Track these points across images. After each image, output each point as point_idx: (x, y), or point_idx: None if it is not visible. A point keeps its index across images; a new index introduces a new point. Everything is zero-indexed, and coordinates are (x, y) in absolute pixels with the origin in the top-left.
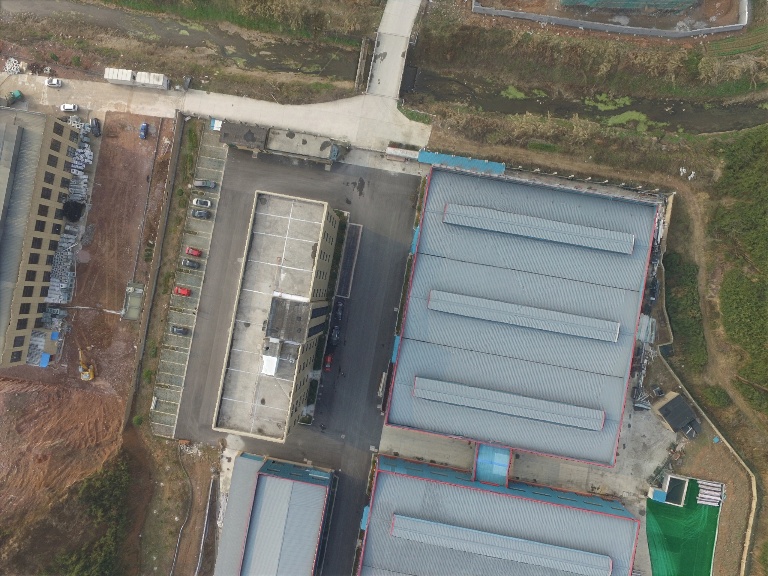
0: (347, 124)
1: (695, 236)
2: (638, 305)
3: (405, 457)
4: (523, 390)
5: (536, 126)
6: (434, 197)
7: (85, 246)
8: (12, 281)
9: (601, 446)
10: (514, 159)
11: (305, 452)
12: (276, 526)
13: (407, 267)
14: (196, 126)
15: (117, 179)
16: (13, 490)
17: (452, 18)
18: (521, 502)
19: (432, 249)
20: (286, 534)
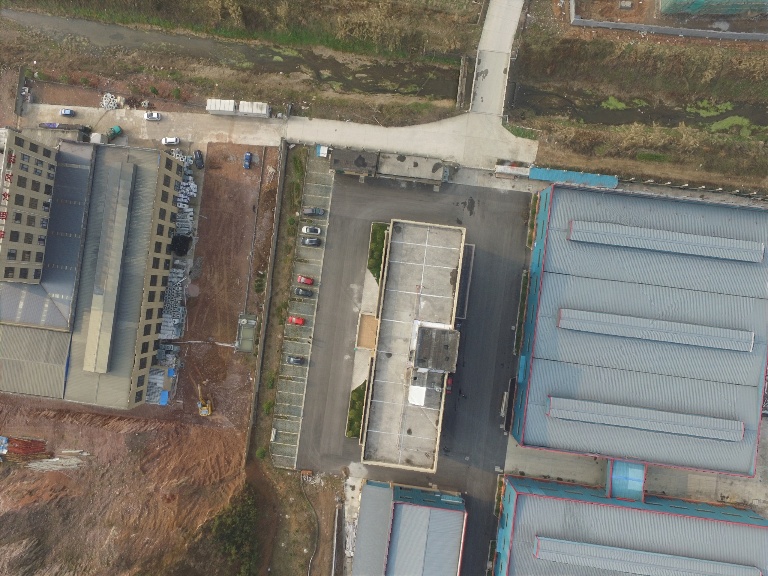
0: (453, 144)
1: None
2: None
3: (532, 476)
4: (657, 404)
5: (646, 137)
6: (556, 215)
7: (194, 280)
8: (134, 321)
9: (739, 456)
10: (624, 171)
11: (430, 476)
12: (415, 554)
13: (523, 285)
14: (300, 153)
15: (223, 210)
16: (147, 532)
17: (551, 32)
18: (663, 517)
19: (557, 267)
20: (426, 562)
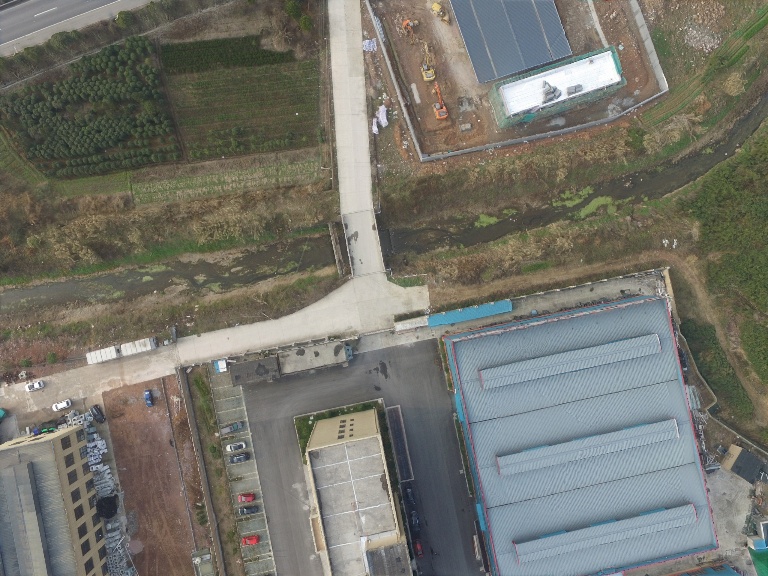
0: (347, 314)
1: (699, 298)
2: (682, 392)
3: None
4: (613, 512)
5: (524, 252)
6: (464, 367)
7: (133, 535)
8: None
9: (700, 532)
10: (514, 288)
11: None
12: None
13: (457, 428)
14: (200, 373)
15: (140, 456)
16: None
17: (405, 175)
18: None
19: (481, 415)
20: None
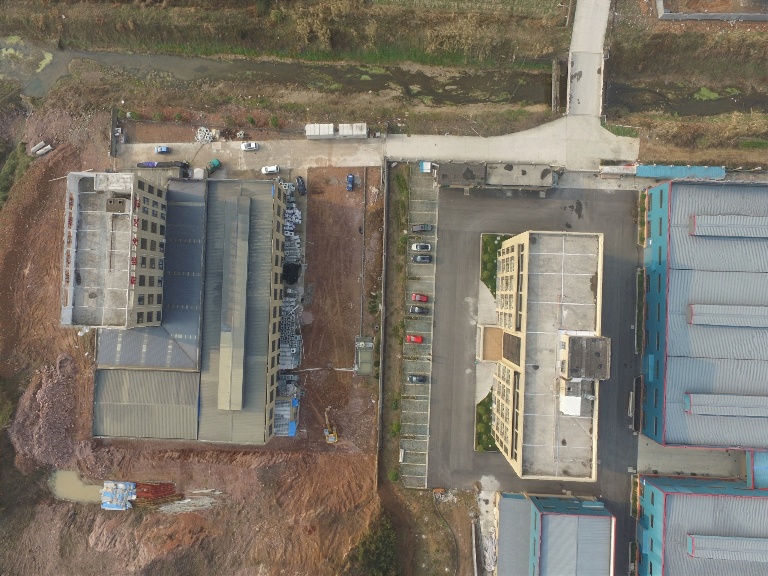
0: (554, 148)
1: None
2: None
3: (666, 474)
4: None
5: (748, 125)
6: (676, 211)
7: (306, 307)
8: (262, 355)
9: None
10: (728, 161)
11: (563, 483)
12: (567, 564)
13: (638, 283)
14: (402, 171)
15: (329, 235)
16: (296, 567)
17: (640, 28)
18: None
19: (681, 263)
20: (578, 570)
